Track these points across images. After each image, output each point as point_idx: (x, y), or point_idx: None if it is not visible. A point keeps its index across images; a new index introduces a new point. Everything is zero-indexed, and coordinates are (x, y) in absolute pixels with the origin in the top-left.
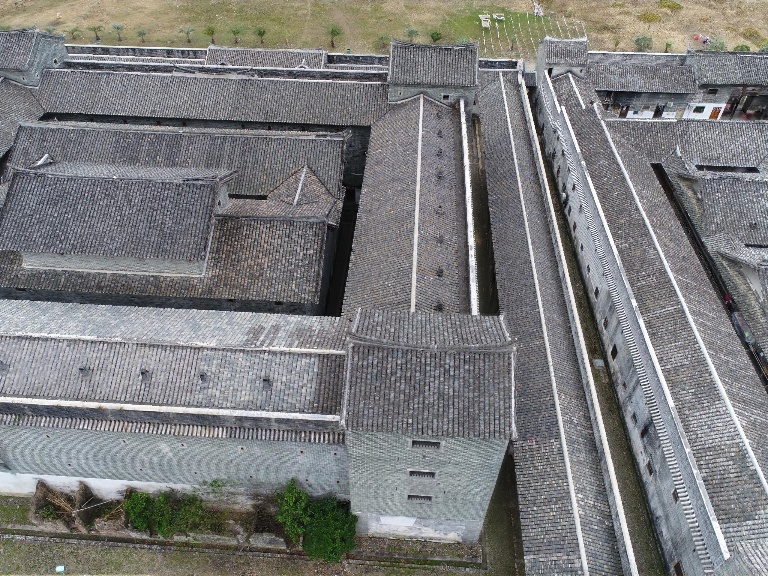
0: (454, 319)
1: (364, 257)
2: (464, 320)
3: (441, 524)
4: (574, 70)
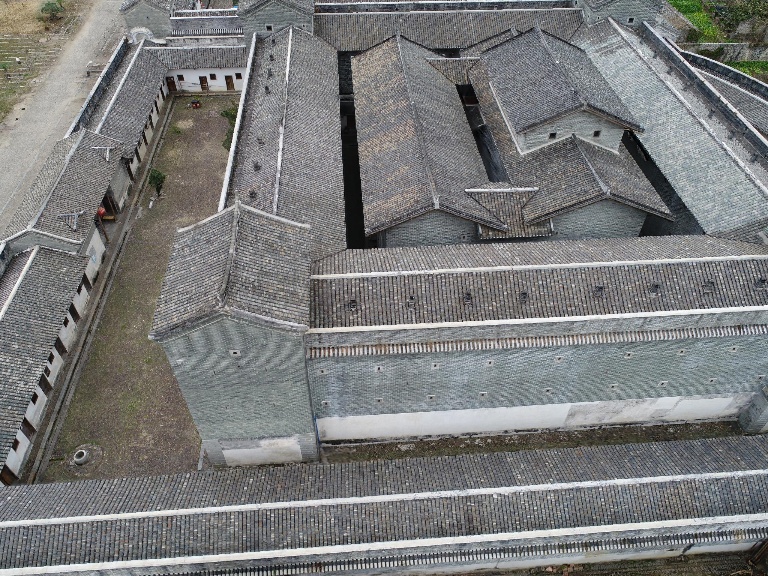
0: None
1: None
2: None
3: None
4: (173, 7)
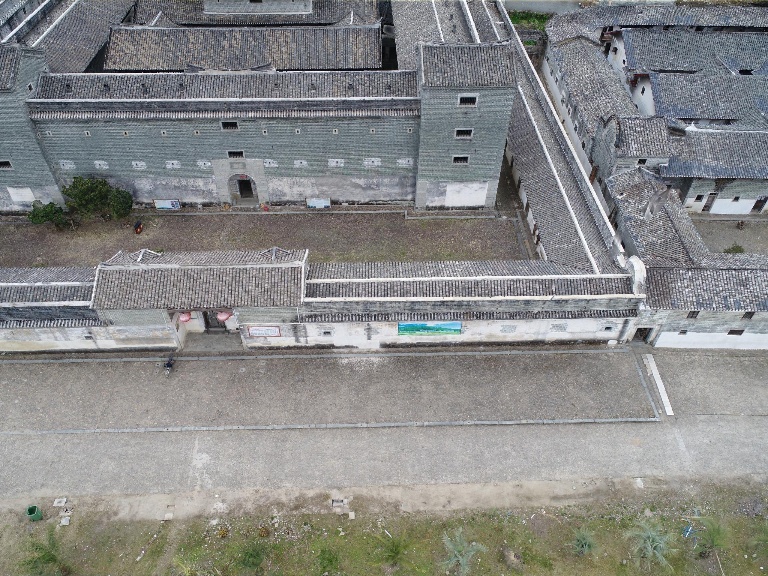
0: None
1: (124, 1)
2: None
3: (129, 21)
4: None
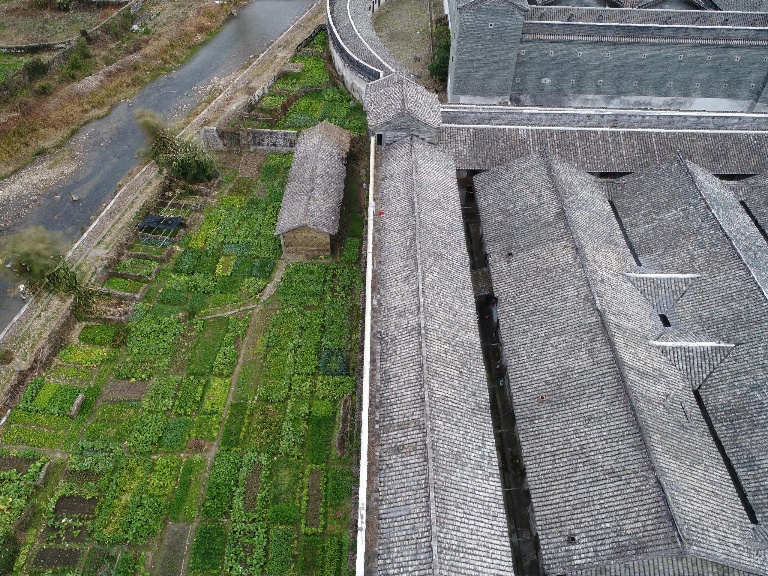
0: None
1: None
2: None
3: None
4: None
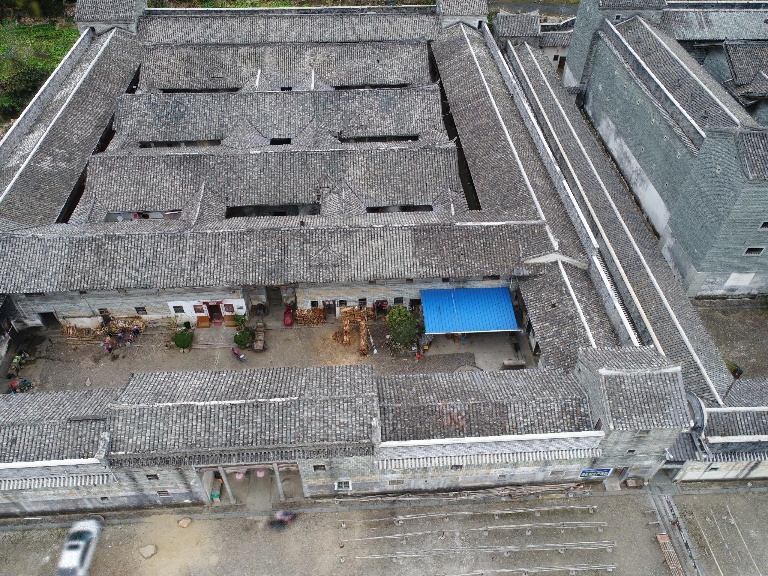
0: (622, 1)
1: None
2: (617, 1)
3: None
4: None
